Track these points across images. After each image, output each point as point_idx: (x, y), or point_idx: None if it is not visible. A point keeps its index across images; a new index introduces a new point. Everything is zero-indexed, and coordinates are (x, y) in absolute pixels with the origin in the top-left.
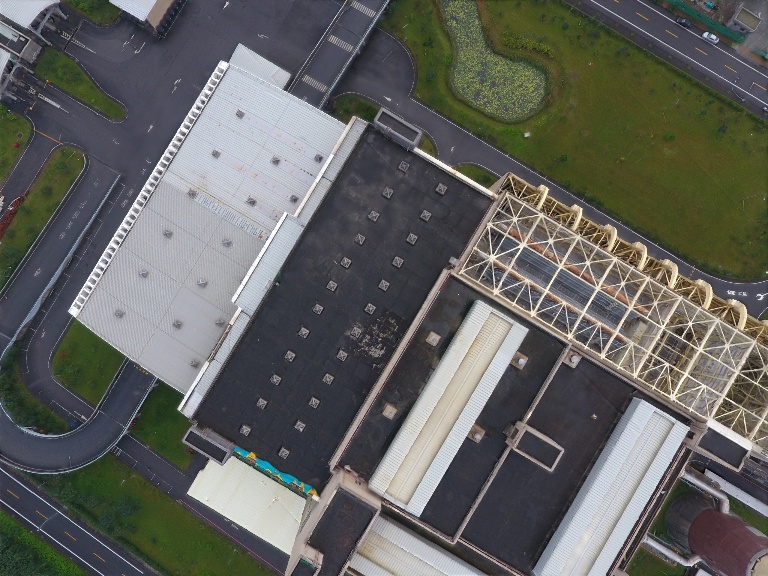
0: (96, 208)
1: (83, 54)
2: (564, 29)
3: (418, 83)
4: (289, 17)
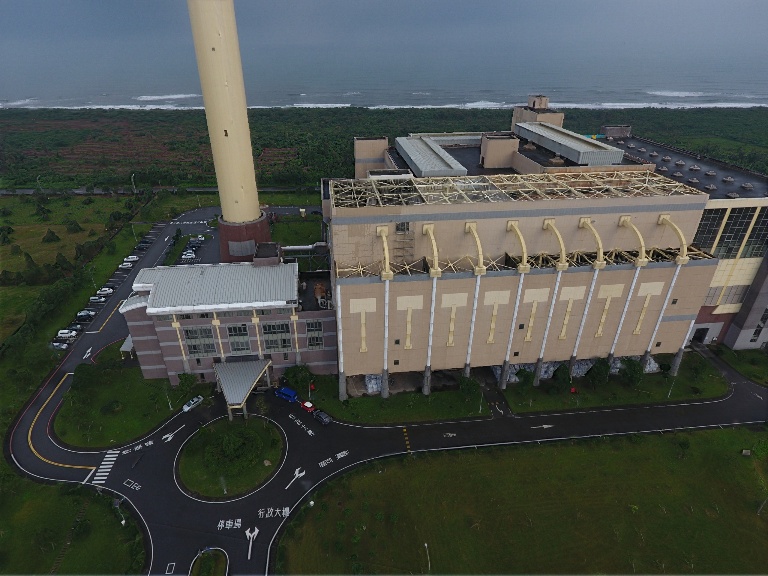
0: None
1: None
2: None
3: None
4: None
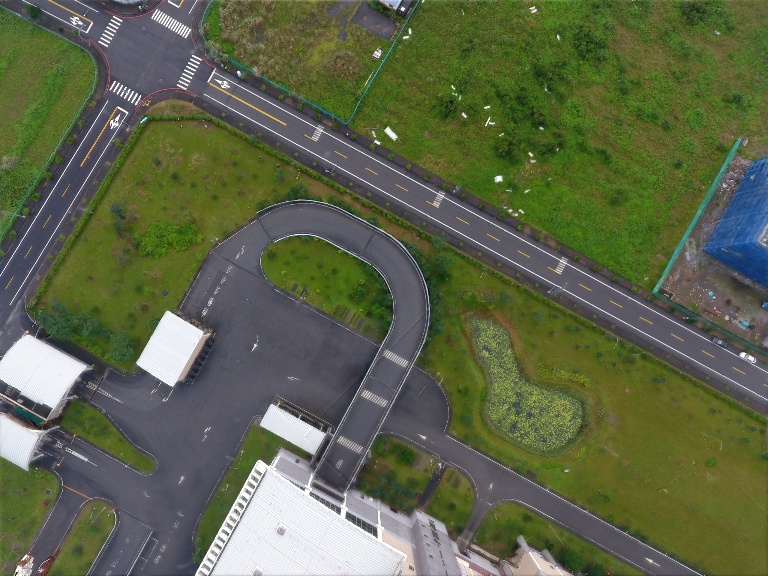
0: (129, 566)
1: (110, 404)
2: (599, 357)
3: (453, 419)
4: (319, 357)
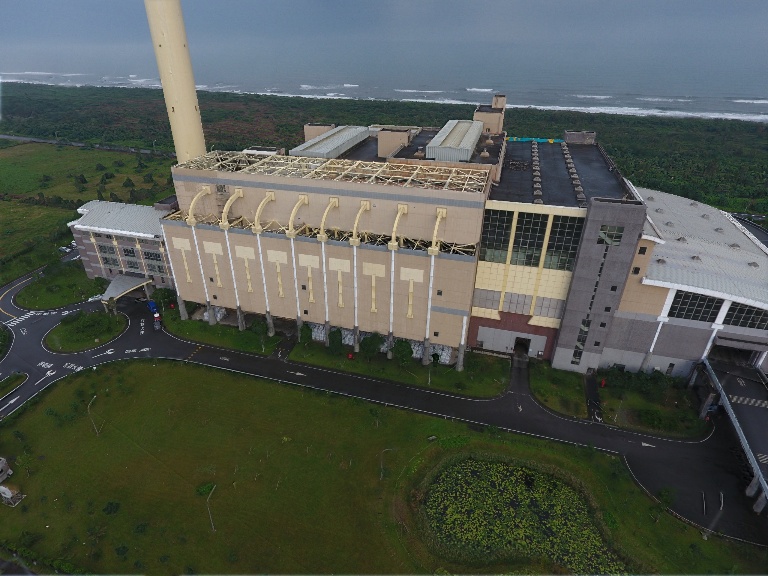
0: None
1: None
2: None
3: None
4: None
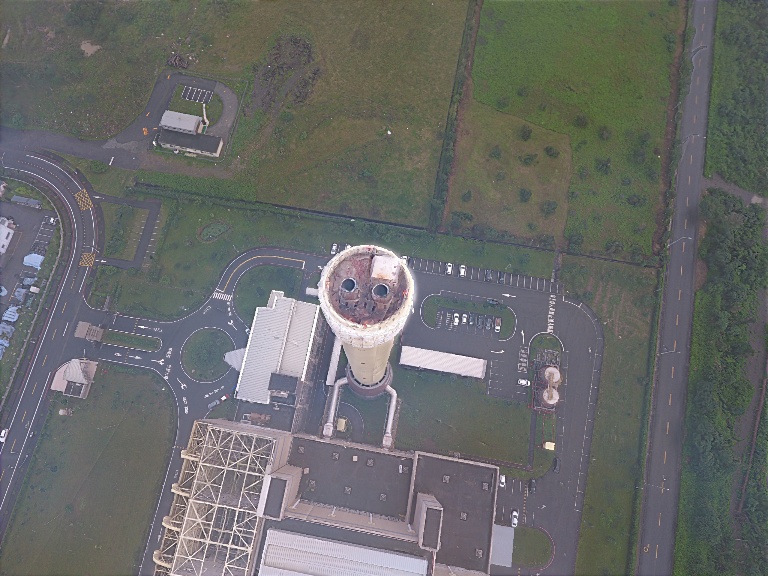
0: None
1: None
2: None
3: None
4: None
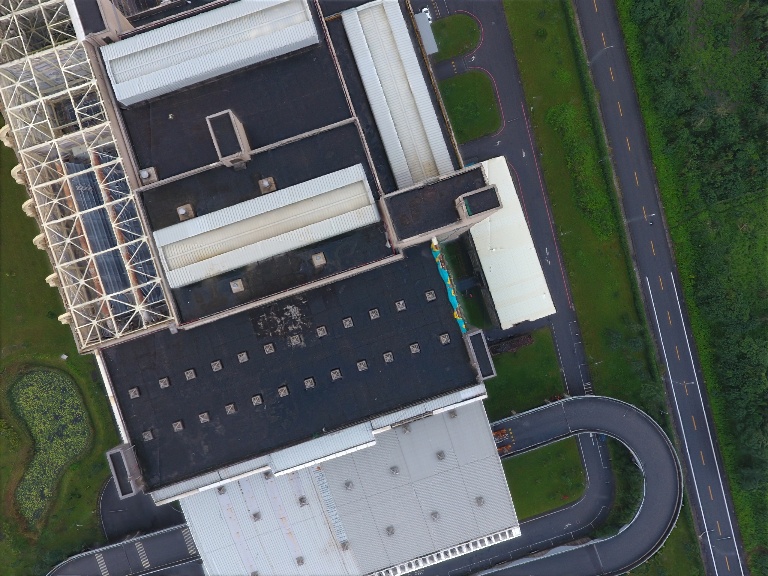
0: None
1: None
2: None
3: None
4: None
